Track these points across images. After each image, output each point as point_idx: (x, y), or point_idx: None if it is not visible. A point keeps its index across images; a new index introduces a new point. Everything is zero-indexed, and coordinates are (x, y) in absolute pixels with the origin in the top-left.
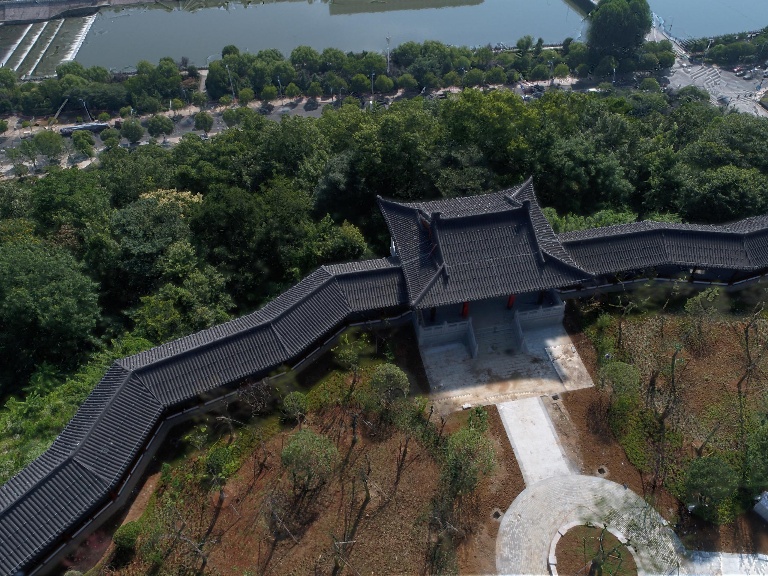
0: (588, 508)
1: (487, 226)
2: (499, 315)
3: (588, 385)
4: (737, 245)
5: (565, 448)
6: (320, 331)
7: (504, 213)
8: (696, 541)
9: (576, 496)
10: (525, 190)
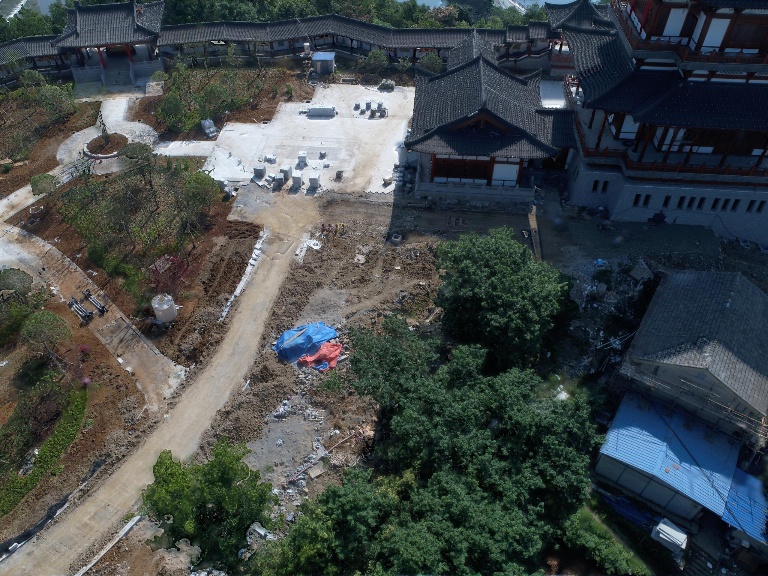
0: (121, 130)
1: (109, 12)
2: (125, 68)
3: (159, 94)
4: (264, 29)
5: (127, 114)
6: (6, 61)
7: (120, 5)
8: (166, 138)
9: (118, 127)
10: (156, 6)
